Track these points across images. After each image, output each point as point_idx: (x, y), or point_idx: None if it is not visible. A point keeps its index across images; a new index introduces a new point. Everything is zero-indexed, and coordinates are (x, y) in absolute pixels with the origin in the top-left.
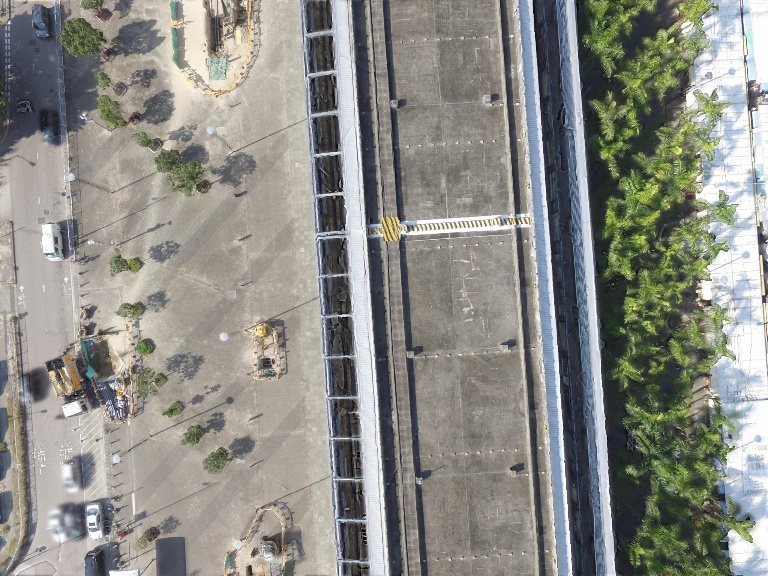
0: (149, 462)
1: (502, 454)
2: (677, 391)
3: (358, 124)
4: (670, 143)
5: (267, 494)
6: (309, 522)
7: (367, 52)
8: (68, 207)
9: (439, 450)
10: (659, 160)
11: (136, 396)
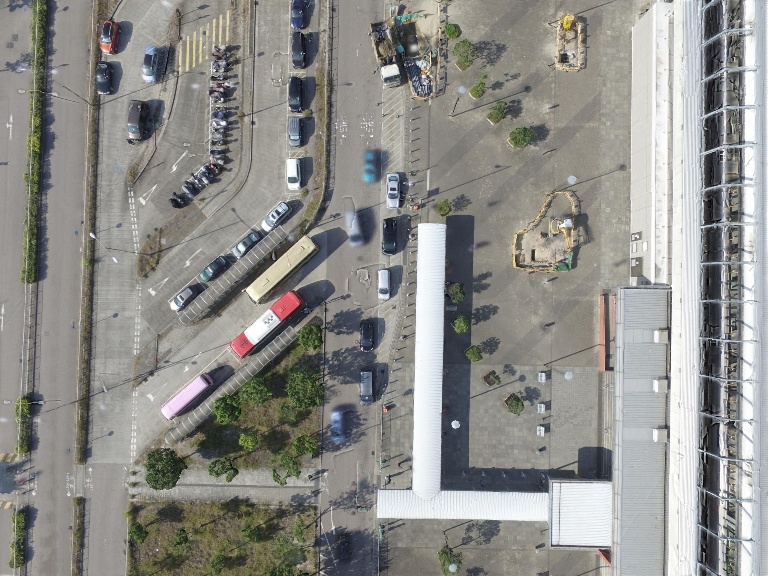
0: (446, 141)
1: None
2: None
3: None
4: None
5: (557, 181)
6: (596, 211)
7: None
8: None
9: None
10: None
11: (439, 78)
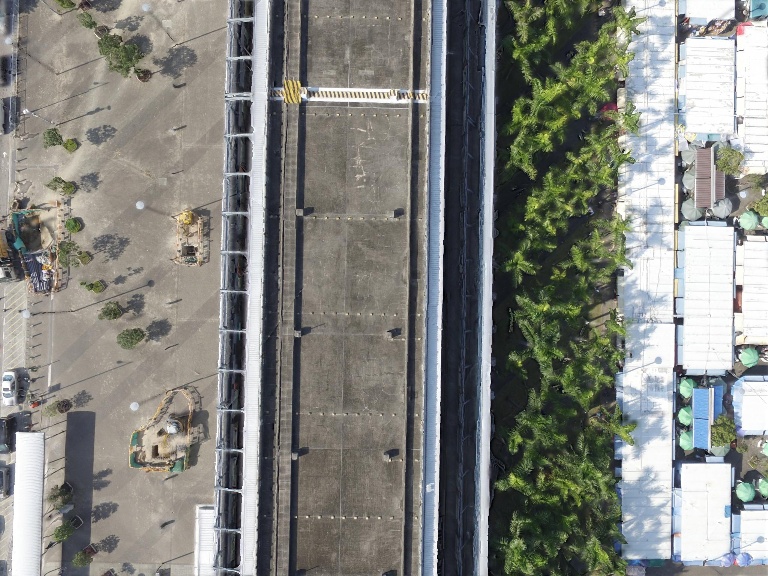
0: (68, 336)
1: (381, 318)
2: (572, 293)
3: None
4: (585, 54)
5: (179, 377)
6: None
7: None
8: (13, 84)
9: (321, 308)
10: (573, 70)
11: (61, 272)
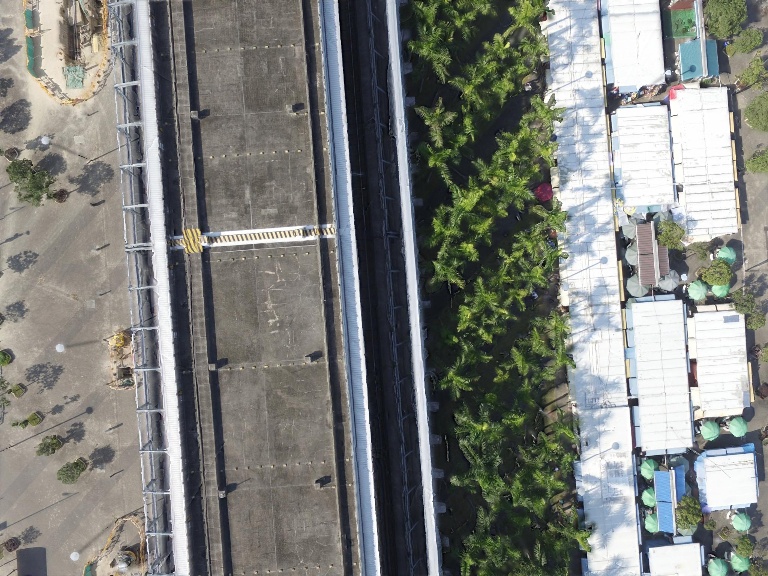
0: (9, 472)
1: (309, 467)
2: (514, 400)
3: (157, 135)
4: (507, 149)
5: (127, 504)
6: None
7: (170, 62)
8: None
9: (245, 463)
10: (496, 167)
11: None
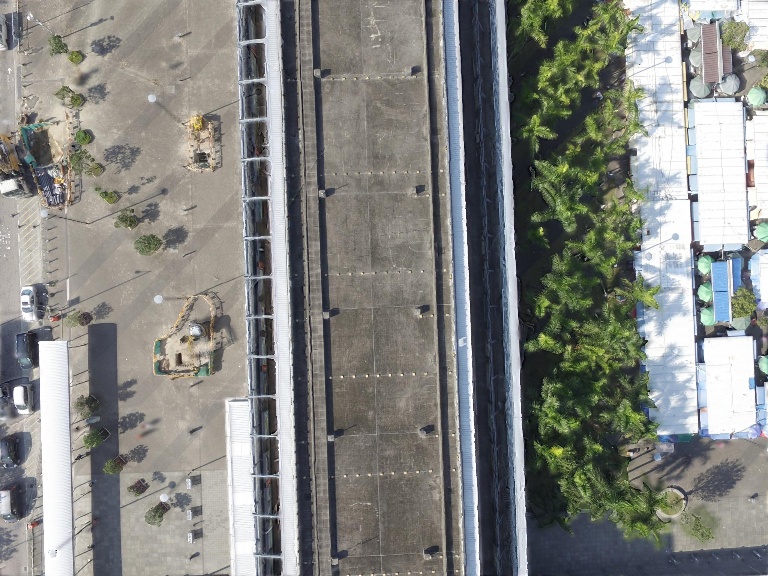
0: (84, 249)
1: (404, 176)
2: (589, 161)
3: None
4: None
5: (199, 284)
6: (238, 312)
7: None
8: None
9: (343, 169)
10: None
11: (74, 185)
